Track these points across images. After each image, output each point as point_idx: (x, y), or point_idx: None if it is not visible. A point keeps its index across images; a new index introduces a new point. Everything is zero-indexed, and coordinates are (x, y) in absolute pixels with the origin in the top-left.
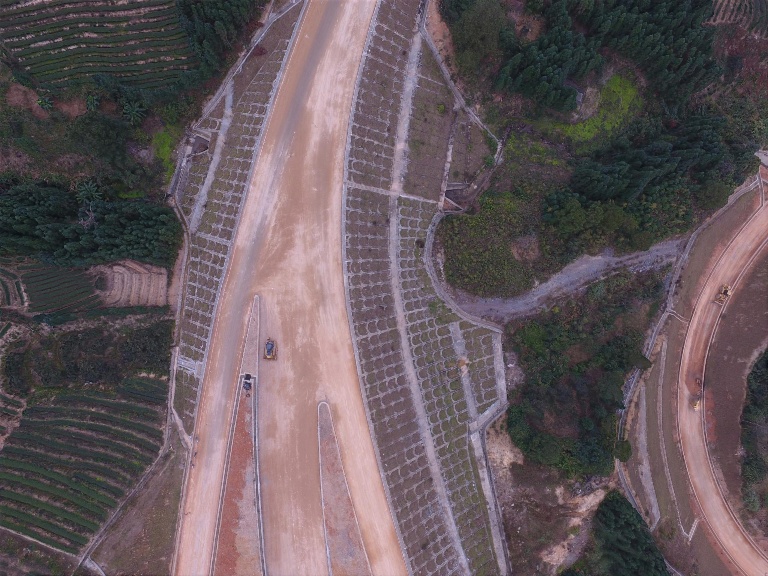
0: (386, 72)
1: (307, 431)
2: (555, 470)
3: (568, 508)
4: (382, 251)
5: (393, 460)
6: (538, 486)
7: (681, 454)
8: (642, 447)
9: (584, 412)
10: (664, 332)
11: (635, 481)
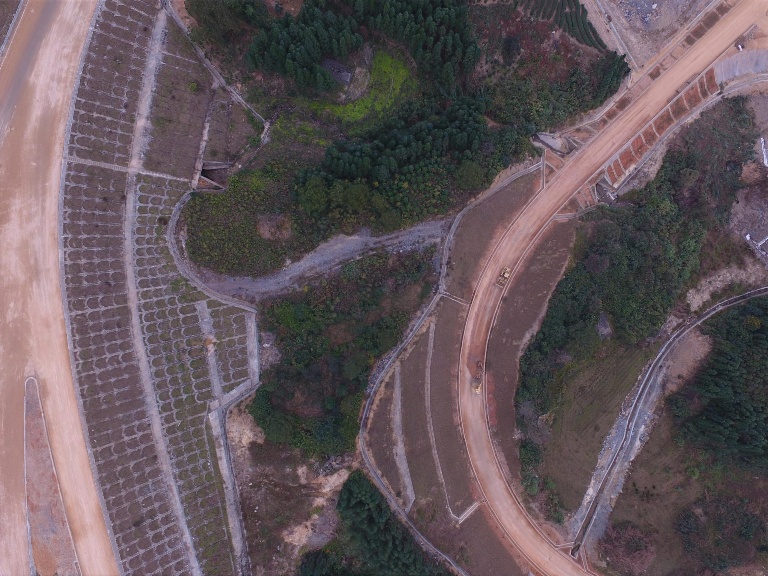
0: (121, 48)
1: (14, 406)
2: (297, 449)
3: (311, 488)
4: (114, 227)
5: (105, 436)
6: (277, 465)
7: (462, 437)
8: (397, 428)
9: (334, 392)
10: (435, 314)
11: (384, 461)
